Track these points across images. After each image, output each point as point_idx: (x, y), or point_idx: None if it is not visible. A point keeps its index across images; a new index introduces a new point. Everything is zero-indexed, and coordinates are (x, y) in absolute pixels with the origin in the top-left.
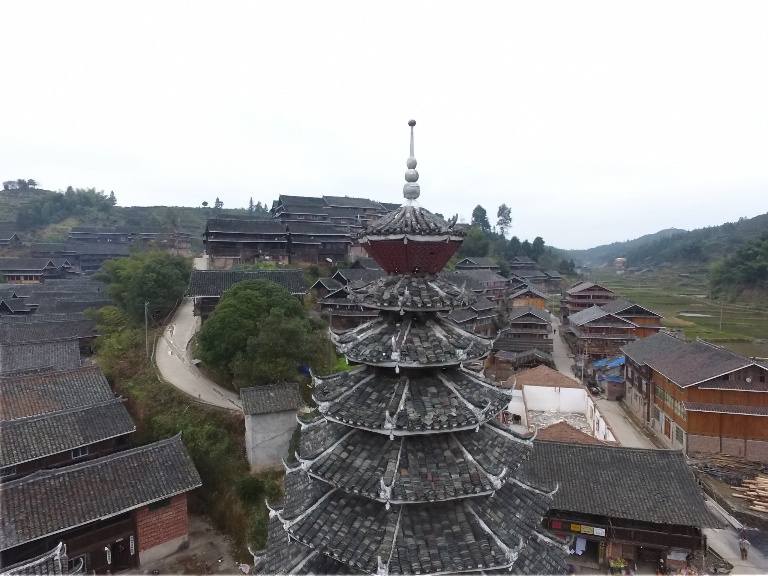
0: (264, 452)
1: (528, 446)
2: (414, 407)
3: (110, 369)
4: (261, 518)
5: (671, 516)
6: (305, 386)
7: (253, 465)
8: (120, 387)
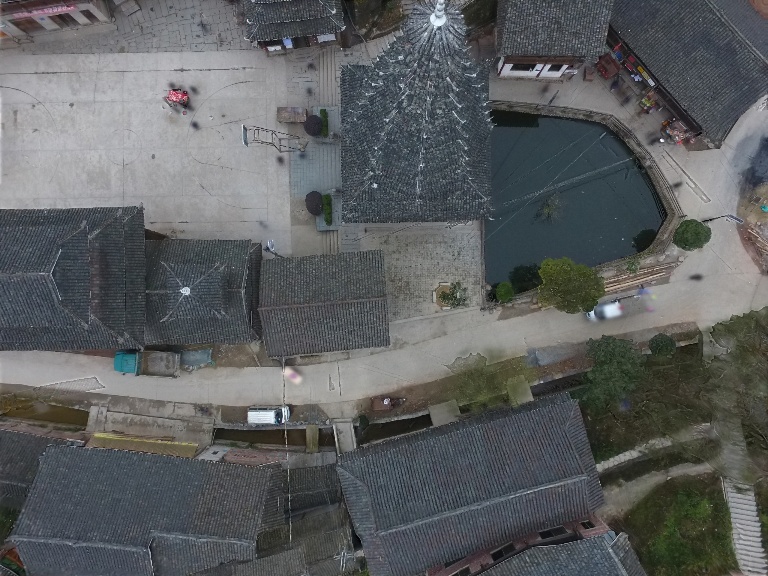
0: None
1: (461, 122)
2: (408, 100)
3: None
4: None
5: (696, 110)
6: None
7: None
8: None
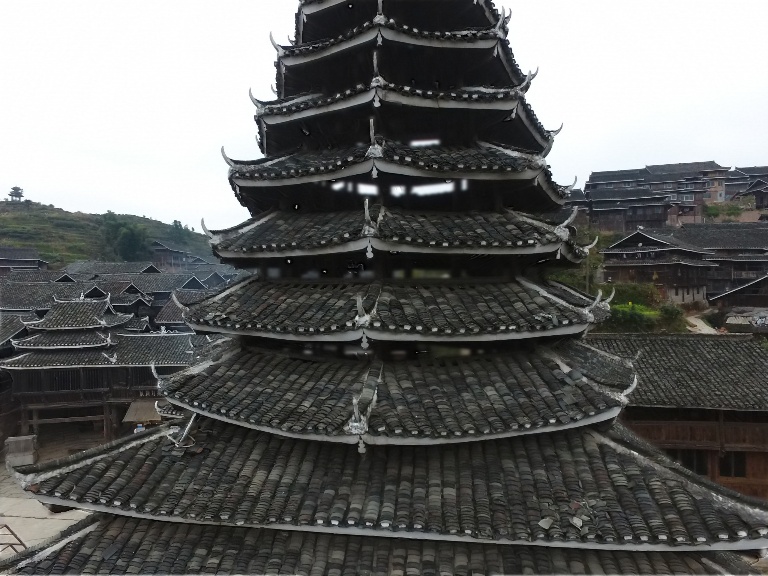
0: None
1: None
2: None
3: None
4: None
5: None
6: None
7: None
8: None
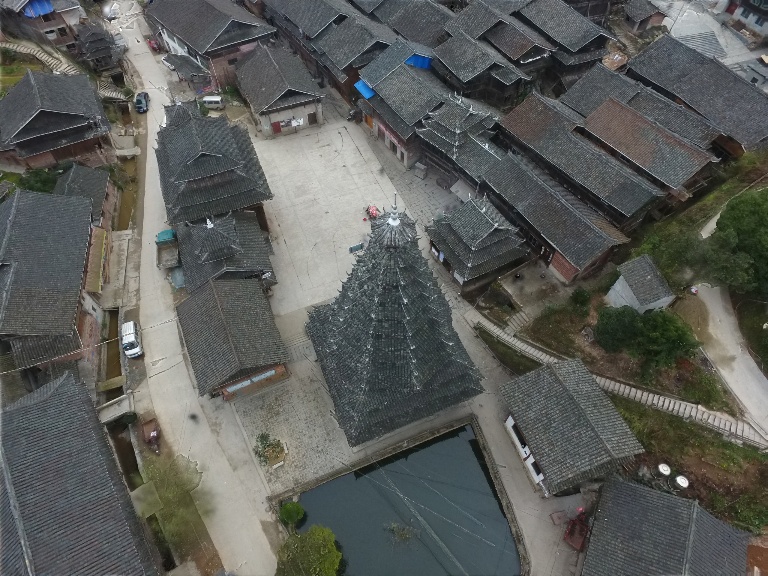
0: (615, 297)
1: None
2: None
3: (751, 163)
4: (551, 307)
5: None
6: (764, 321)
7: (607, 295)
8: (725, 183)
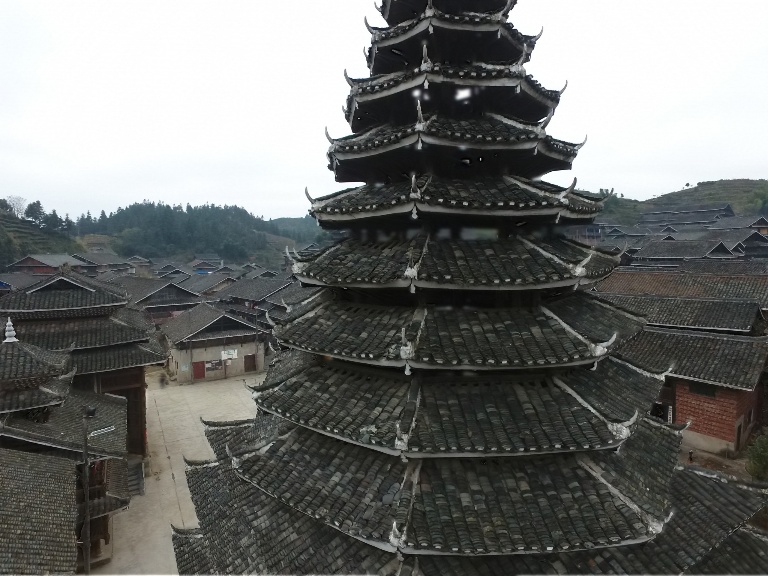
0: None
1: None
2: None
3: None
4: (765, 440)
5: None
6: None
7: None
8: None
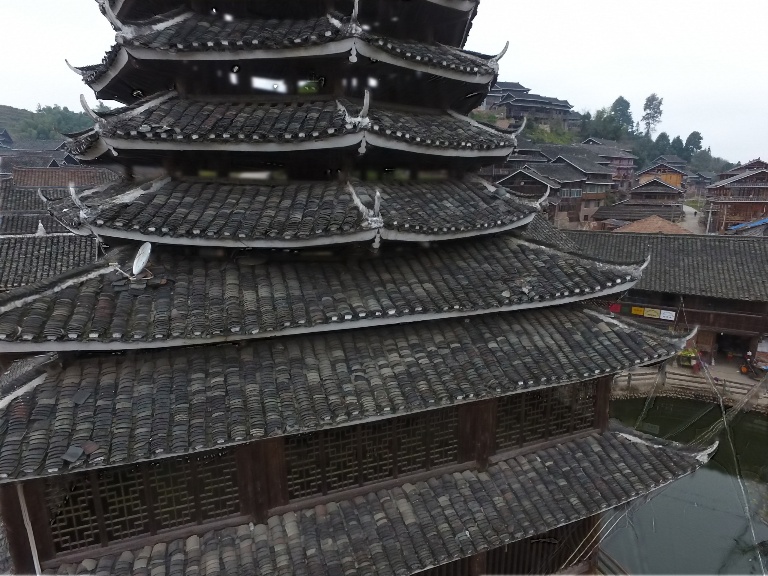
0: None
1: None
2: None
3: None
4: None
5: None
6: None
7: None
8: None
